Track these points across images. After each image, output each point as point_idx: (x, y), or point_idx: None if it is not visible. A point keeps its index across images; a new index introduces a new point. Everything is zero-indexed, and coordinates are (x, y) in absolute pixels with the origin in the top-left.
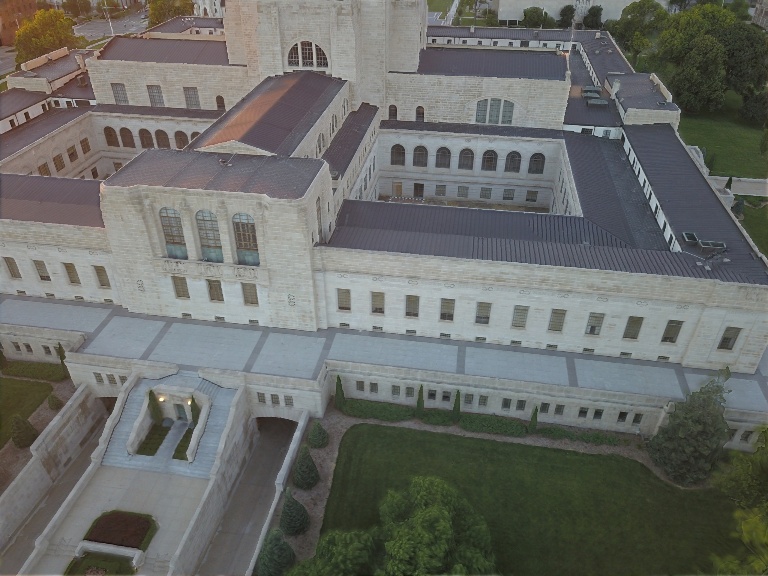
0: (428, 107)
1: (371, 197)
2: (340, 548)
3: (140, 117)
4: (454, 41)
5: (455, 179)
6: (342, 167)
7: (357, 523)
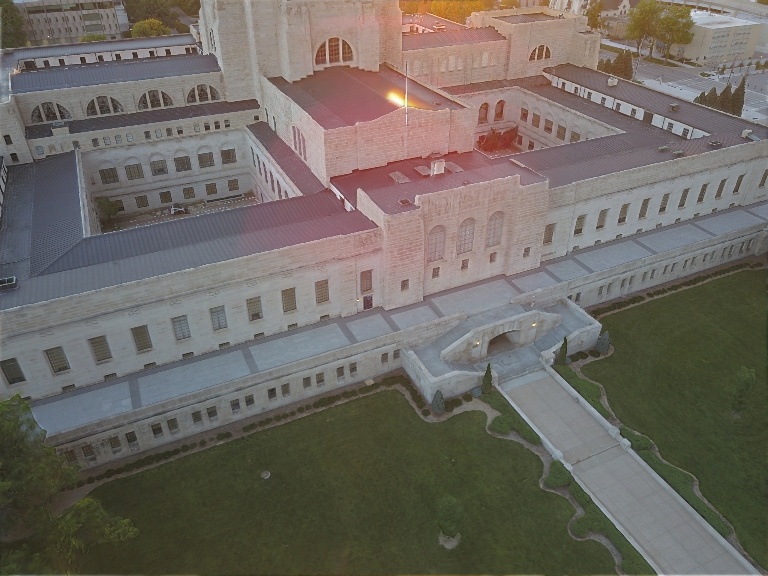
0: (276, 119)
1: (206, 182)
2: None
3: None
4: (580, 90)
5: (270, 200)
6: (102, 128)
7: None
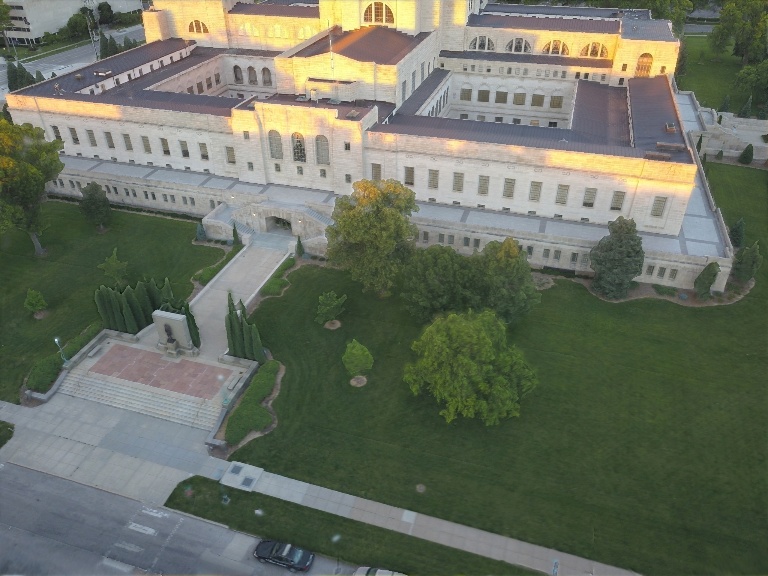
0: None
1: None
2: None
3: (431, 99)
4: None
5: None
6: None
7: (735, 110)
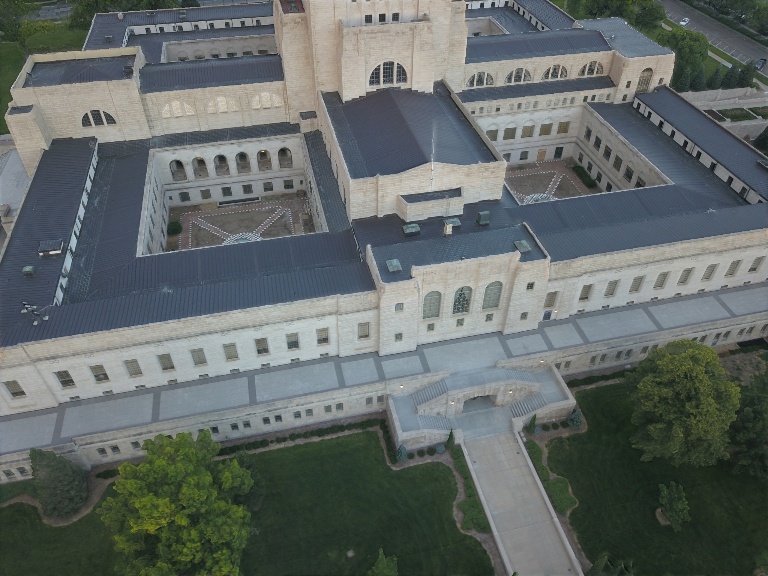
0: None
1: None
2: (690, 42)
3: None
4: None
5: None
6: None
7: None
